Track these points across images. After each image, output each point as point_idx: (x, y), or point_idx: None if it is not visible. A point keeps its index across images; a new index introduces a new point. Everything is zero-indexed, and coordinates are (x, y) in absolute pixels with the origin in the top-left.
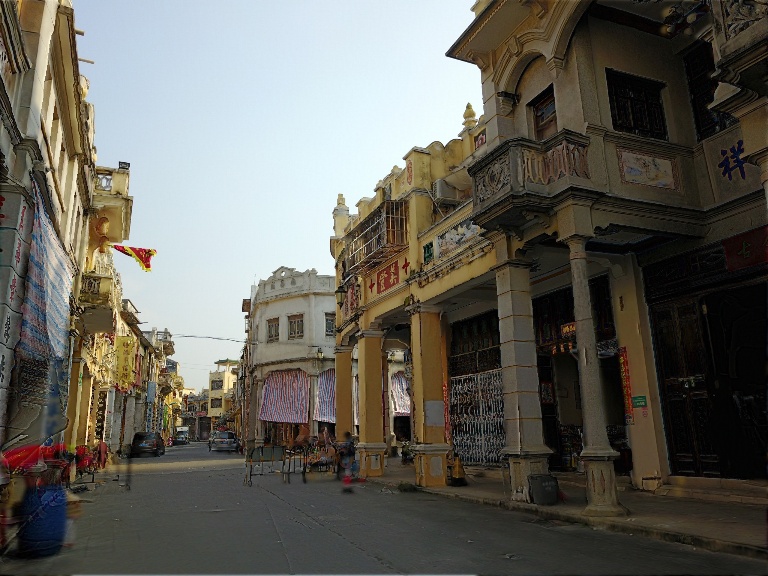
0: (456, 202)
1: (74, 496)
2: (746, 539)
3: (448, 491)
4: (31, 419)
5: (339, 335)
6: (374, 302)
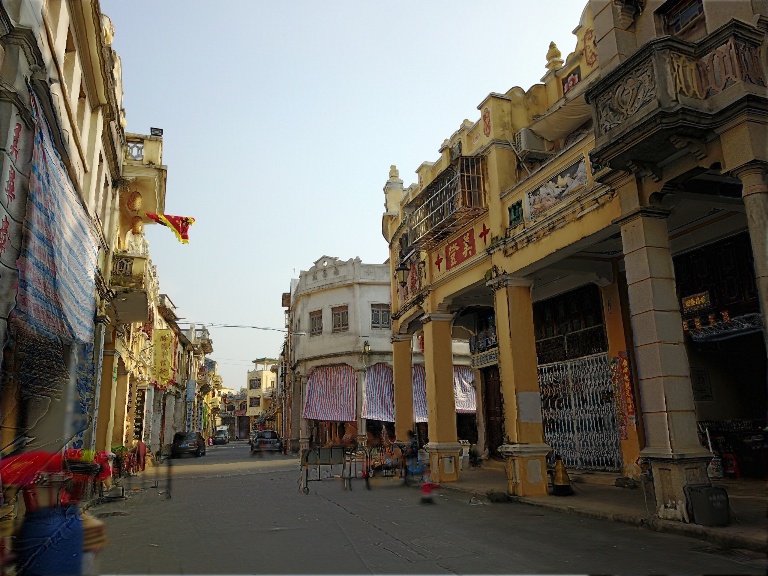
0: (544, 155)
1: (108, 506)
2: None
3: (555, 502)
4: (37, 416)
5: (396, 322)
6: (443, 279)
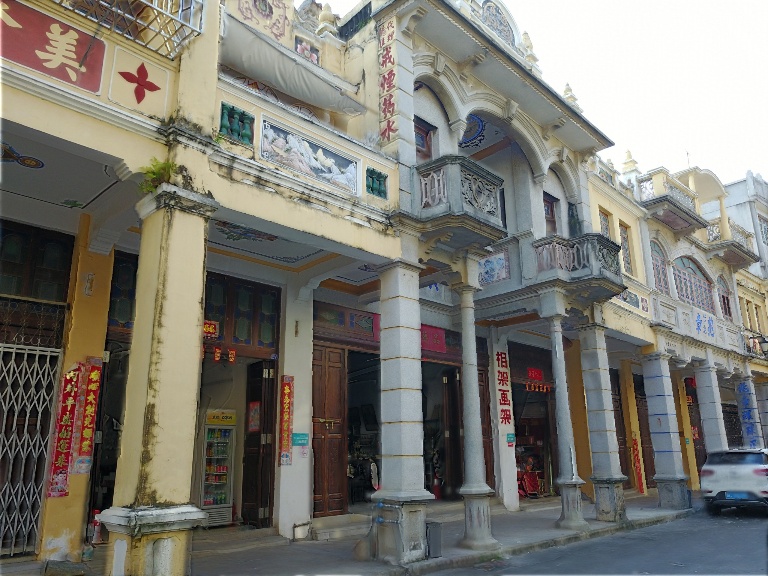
0: None
1: None
2: (551, 535)
3: None
4: None
5: None
6: None
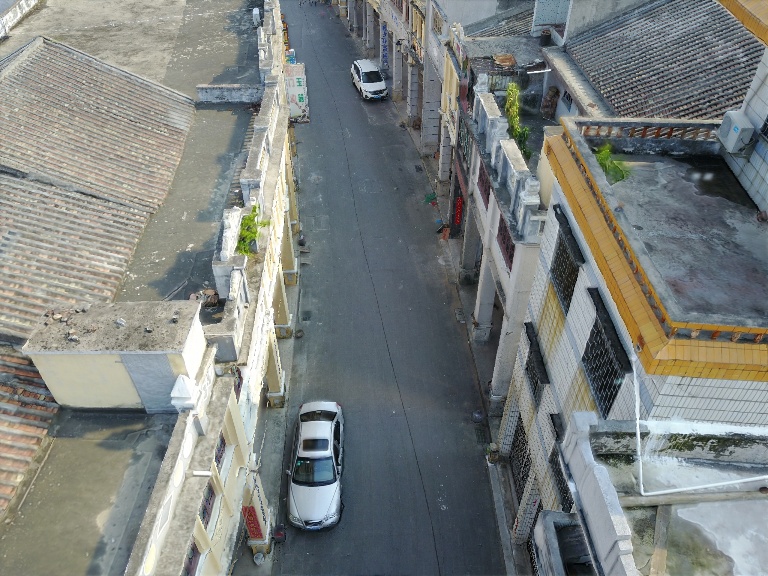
0: None
1: None
2: (362, 45)
3: None
4: None
5: None
6: None
